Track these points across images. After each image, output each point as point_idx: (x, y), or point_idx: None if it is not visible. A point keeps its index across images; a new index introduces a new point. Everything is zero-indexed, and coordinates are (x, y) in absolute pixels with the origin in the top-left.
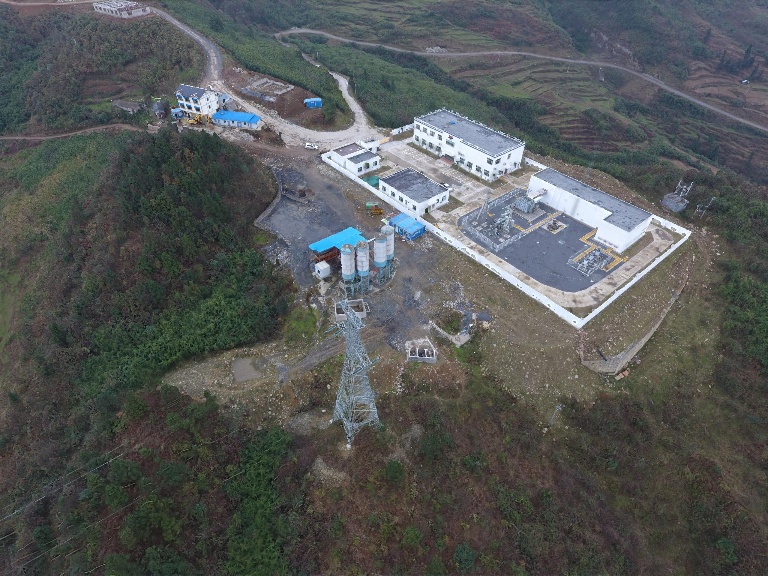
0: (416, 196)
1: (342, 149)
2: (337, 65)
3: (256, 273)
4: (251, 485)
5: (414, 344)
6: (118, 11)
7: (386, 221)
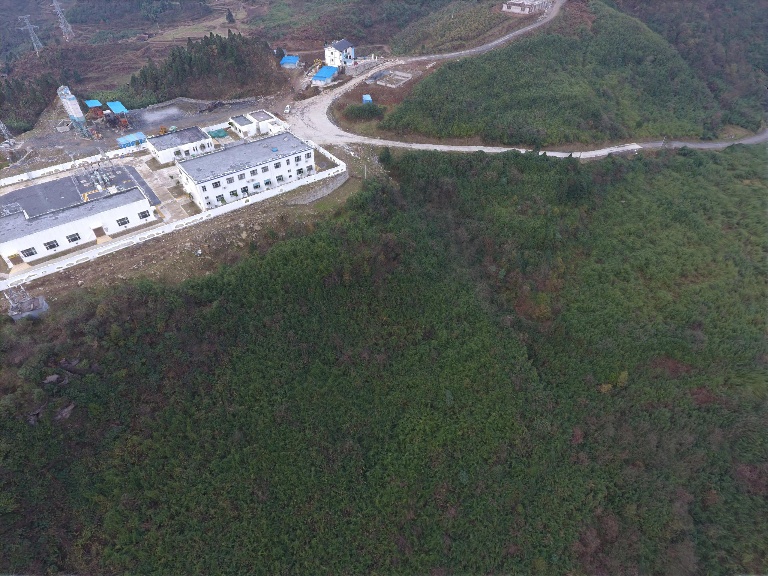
0: (161, 139)
1: (265, 114)
2: (675, 166)
3: (133, 105)
4: (5, 123)
5: (19, 144)
6: (506, 3)
7: (150, 136)
